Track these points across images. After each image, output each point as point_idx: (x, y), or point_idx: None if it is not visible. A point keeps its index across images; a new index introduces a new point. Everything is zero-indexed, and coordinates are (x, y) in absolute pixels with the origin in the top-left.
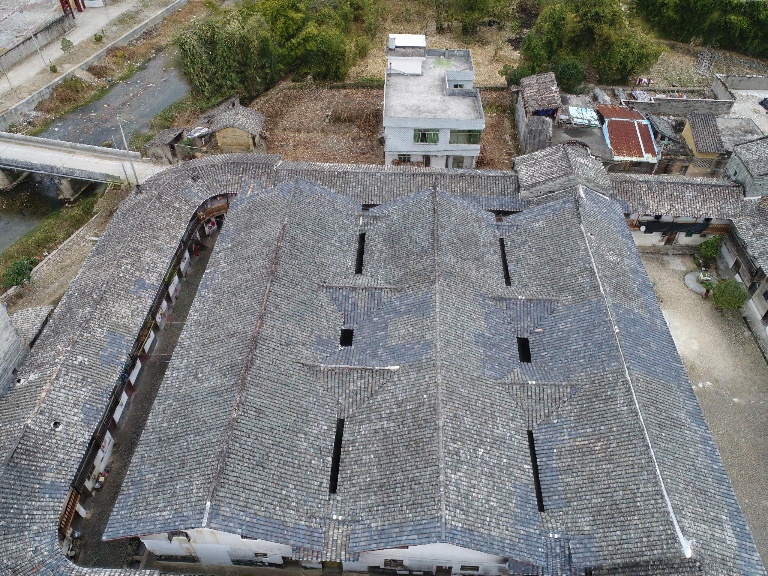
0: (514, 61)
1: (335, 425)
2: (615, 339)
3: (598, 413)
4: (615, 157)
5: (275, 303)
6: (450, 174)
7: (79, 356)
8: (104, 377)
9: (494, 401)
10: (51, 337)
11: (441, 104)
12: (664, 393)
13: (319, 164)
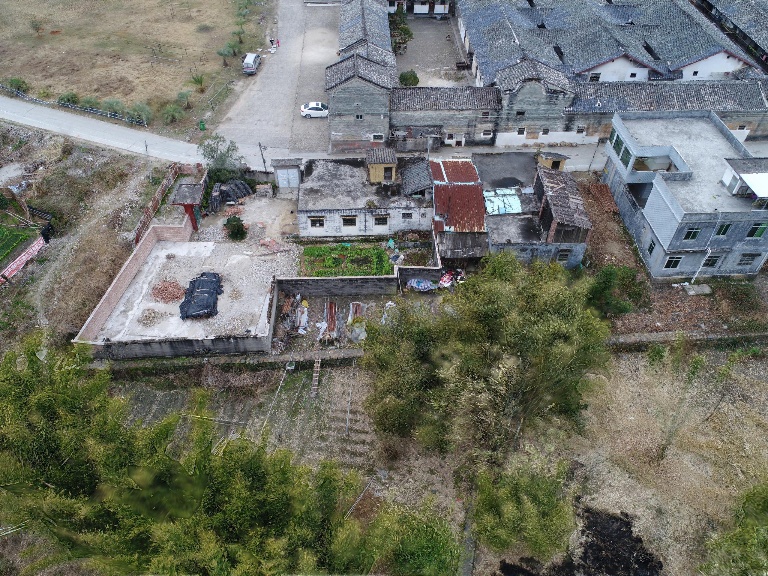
0: (616, 455)
1: (614, 2)
2: (504, 8)
3: (510, 1)
4: (470, 160)
5: (672, 7)
6: (621, 83)
7: (739, 1)
8: (722, 4)
9: (553, 3)
10: (764, 12)
11: (669, 142)
12: (480, 6)
13: (734, 104)
